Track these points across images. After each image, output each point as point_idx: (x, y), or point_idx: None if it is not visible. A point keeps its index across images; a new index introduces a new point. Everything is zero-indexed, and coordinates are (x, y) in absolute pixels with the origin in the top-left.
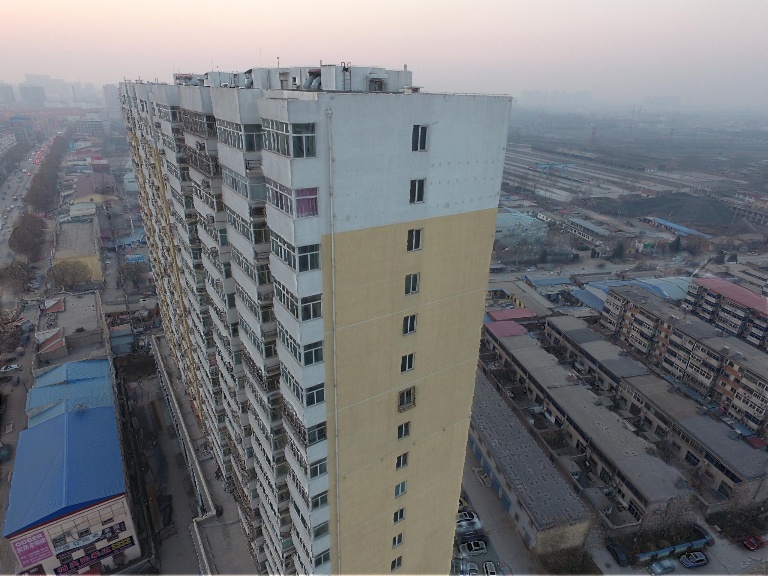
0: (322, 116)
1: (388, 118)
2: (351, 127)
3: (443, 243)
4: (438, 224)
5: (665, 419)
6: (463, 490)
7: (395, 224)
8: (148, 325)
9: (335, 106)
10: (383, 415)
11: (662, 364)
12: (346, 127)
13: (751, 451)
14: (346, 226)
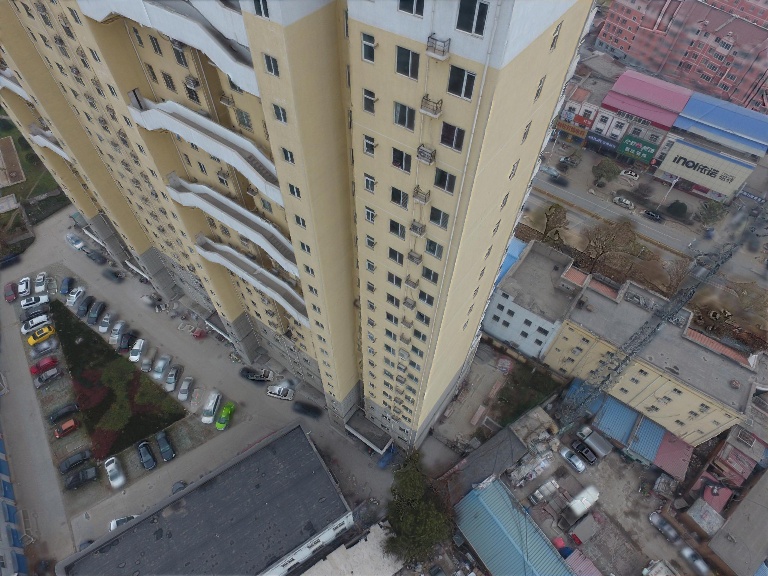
0: None
1: None
2: None
3: None
4: None
5: None
6: (30, 359)
7: None
8: (665, 507)
9: None
10: None
11: None
12: None
13: None
14: None
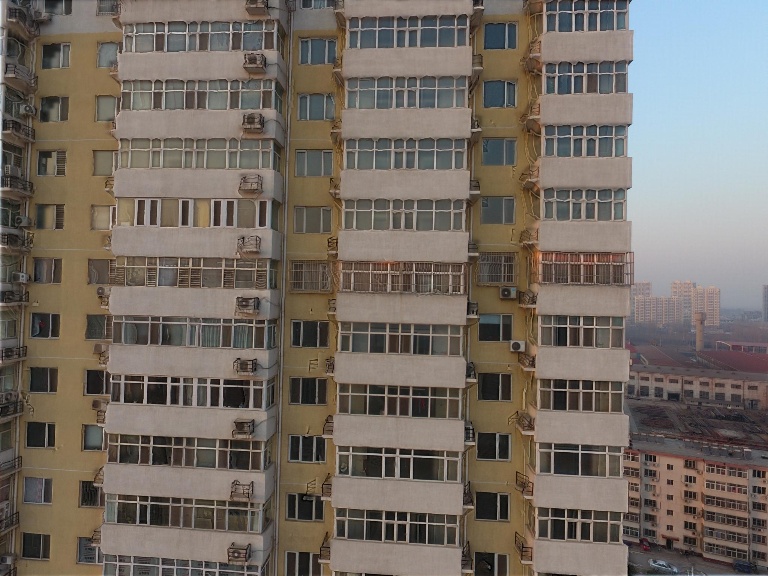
0: None
1: None
2: None
3: None
4: None
5: None
6: None
7: None
8: None
9: None
10: None
11: None
12: None
13: None
14: None
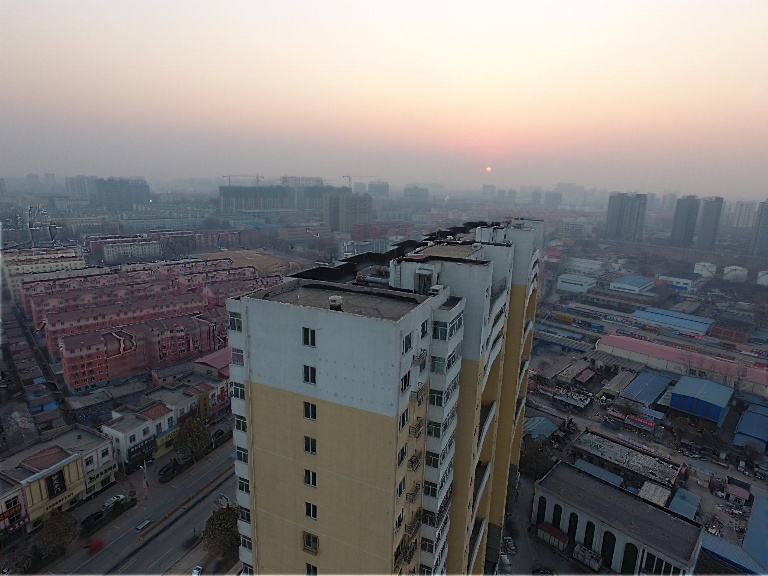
0: (243, 310)
1: (283, 319)
2: (260, 320)
3: (336, 425)
4: (329, 407)
5: None
6: None
7: (293, 392)
8: None
9: (252, 306)
10: (292, 541)
11: None
12: (257, 319)
13: None
14: (259, 380)
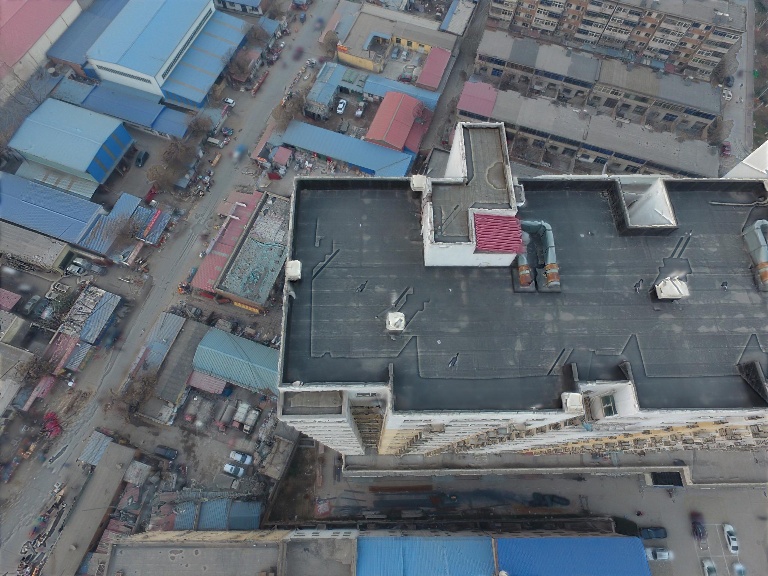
0: None
1: None
2: None
3: None
4: None
5: (646, 99)
6: None
7: None
8: (167, 467)
9: None
10: None
11: (575, 36)
12: None
13: (702, 88)
14: None
